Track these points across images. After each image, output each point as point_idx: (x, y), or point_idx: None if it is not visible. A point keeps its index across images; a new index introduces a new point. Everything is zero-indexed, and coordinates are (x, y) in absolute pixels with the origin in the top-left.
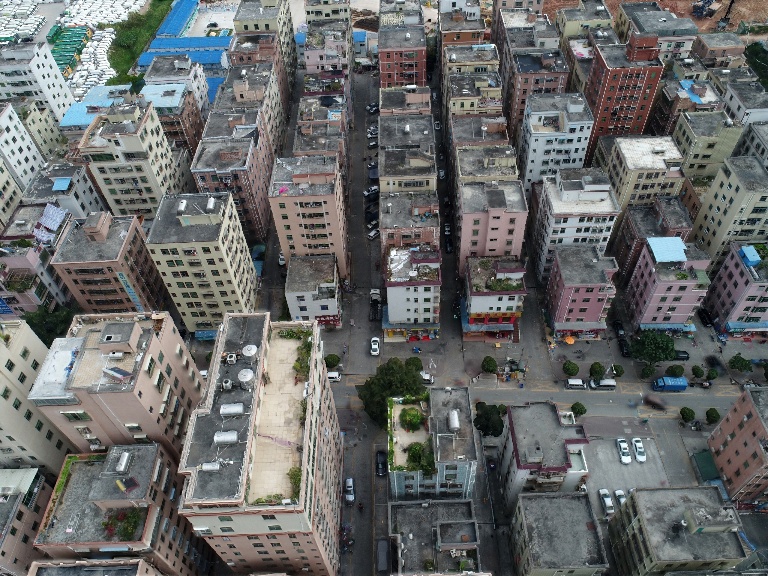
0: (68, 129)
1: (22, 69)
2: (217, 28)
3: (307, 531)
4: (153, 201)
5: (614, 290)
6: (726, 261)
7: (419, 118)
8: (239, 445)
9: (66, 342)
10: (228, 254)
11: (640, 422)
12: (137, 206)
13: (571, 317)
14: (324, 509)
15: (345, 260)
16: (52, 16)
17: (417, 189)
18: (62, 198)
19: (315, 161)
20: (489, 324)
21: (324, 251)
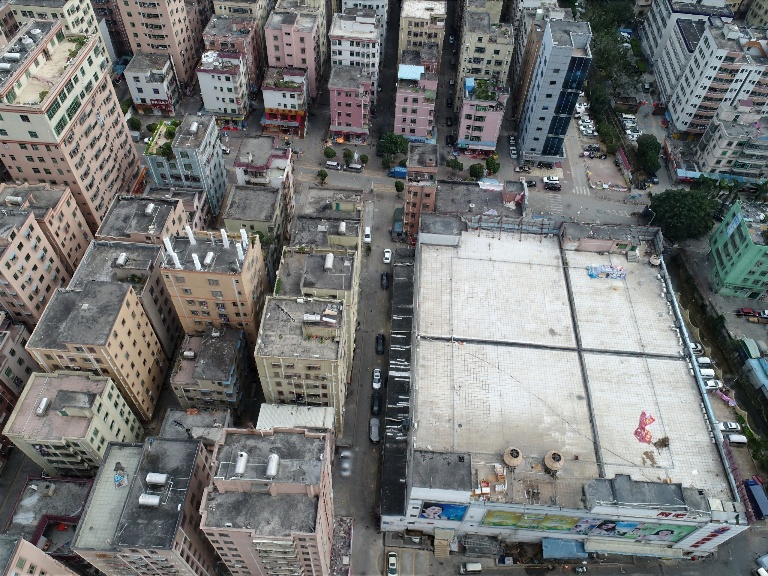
0: None
1: None
2: None
3: (55, 142)
4: None
5: (367, 97)
6: (462, 93)
7: None
8: (12, 74)
9: None
10: (75, 26)
11: (369, 192)
12: None
13: (341, 121)
14: (89, 163)
15: (184, 66)
16: None
17: (244, 16)
18: None
19: None
20: (281, 121)
21: (164, 52)
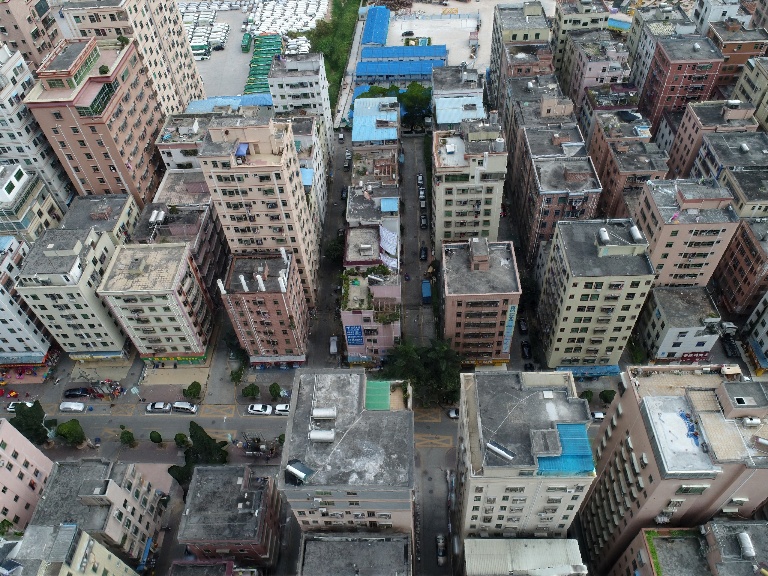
0: (359, 144)
1: (310, 81)
2: (413, 37)
3: None
4: (486, 224)
5: None
6: None
7: (748, 136)
8: None
9: (662, 402)
10: None
11: None
12: (465, 229)
13: None
14: None
15: None
16: (233, 24)
17: None
18: (389, 219)
19: (688, 184)
20: None
21: (688, 281)
